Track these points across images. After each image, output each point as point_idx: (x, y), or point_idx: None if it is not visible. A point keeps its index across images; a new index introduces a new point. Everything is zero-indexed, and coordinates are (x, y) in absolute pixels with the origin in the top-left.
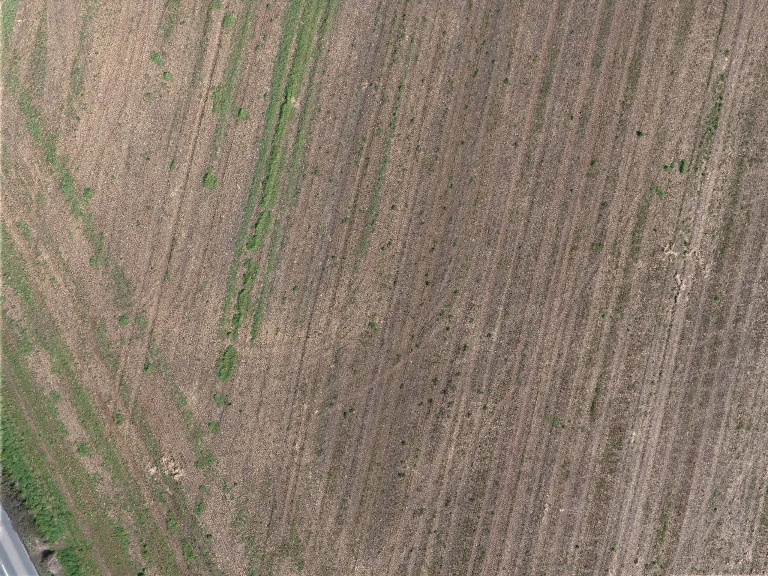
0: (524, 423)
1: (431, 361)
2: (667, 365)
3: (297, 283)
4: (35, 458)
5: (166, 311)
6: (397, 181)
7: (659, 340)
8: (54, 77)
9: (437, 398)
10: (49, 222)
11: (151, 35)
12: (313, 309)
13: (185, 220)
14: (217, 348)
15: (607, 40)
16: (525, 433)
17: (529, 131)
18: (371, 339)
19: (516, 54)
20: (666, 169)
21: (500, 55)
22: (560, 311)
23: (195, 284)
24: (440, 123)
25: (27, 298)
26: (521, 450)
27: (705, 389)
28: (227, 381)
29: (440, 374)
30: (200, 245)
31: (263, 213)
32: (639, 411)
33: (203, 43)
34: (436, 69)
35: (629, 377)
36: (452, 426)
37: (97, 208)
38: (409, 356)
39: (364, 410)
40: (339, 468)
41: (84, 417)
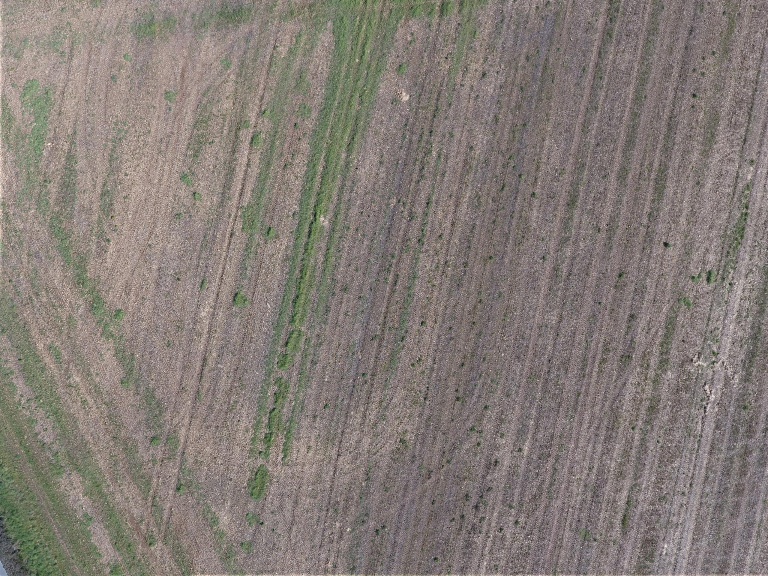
0: (556, 537)
1: (462, 477)
2: (697, 476)
3: (328, 401)
4: None
5: (197, 431)
6: (426, 297)
7: (689, 451)
8: (84, 200)
9: (469, 514)
10: (80, 344)
11: (180, 156)
12: (344, 427)
13: (216, 340)
14: (249, 467)
15: (633, 152)
16: (557, 547)
17: (557, 244)
18: (402, 456)
19: (543, 168)
20: (693, 280)
21: (527, 169)
22: (590, 424)
23: (226, 404)
24: (468, 238)
25: (59, 421)
26: (553, 564)
27: (736, 499)
28: (259, 500)
29: (471, 490)
30: (231, 364)
31: (293, 332)
32: (670, 523)
33: (232, 163)
34: (463, 185)
35: (660, 489)
36: (484, 542)
37: (128, 329)
38: (440, 472)
39: (396, 527)
40: None
41: (117, 539)
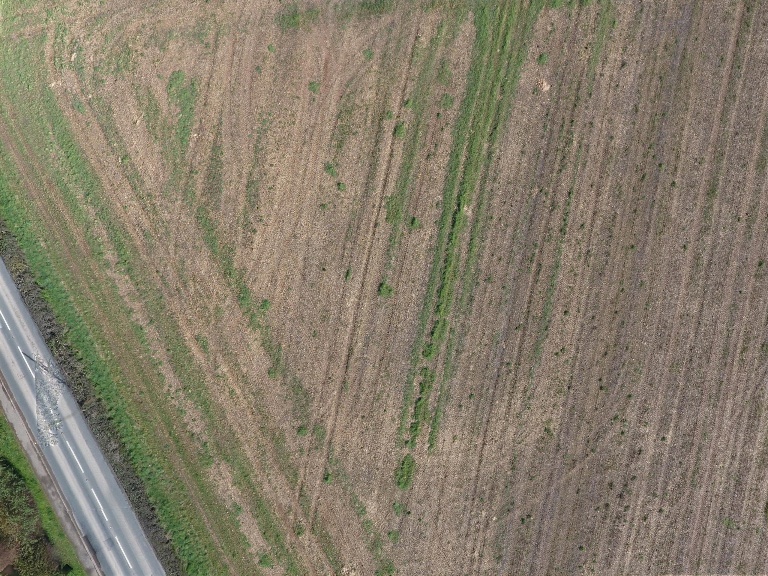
0: (699, 525)
1: (607, 466)
2: None
3: (473, 390)
4: (218, 571)
5: (344, 421)
6: (569, 286)
7: None
8: (230, 190)
9: (613, 502)
10: (227, 334)
11: (324, 146)
12: (489, 416)
13: (361, 330)
14: (395, 457)
15: None
16: (701, 536)
17: (697, 233)
18: (547, 445)
19: (682, 157)
20: None
21: (667, 158)
22: (732, 413)
23: (372, 393)
24: (610, 228)
25: (207, 411)
26: (697, 553)
27: None
28: (406, 490)
29: (616, 478)
30: (376, 354)
31: (439, 322)
32: None
33: (375, 153)
34: (605, 174)
35: None
36: (629, 530)
37: (274, 319)
38: (585, 461)
39: (541, 516)
40: (518, 574)
41: (265, 529)
